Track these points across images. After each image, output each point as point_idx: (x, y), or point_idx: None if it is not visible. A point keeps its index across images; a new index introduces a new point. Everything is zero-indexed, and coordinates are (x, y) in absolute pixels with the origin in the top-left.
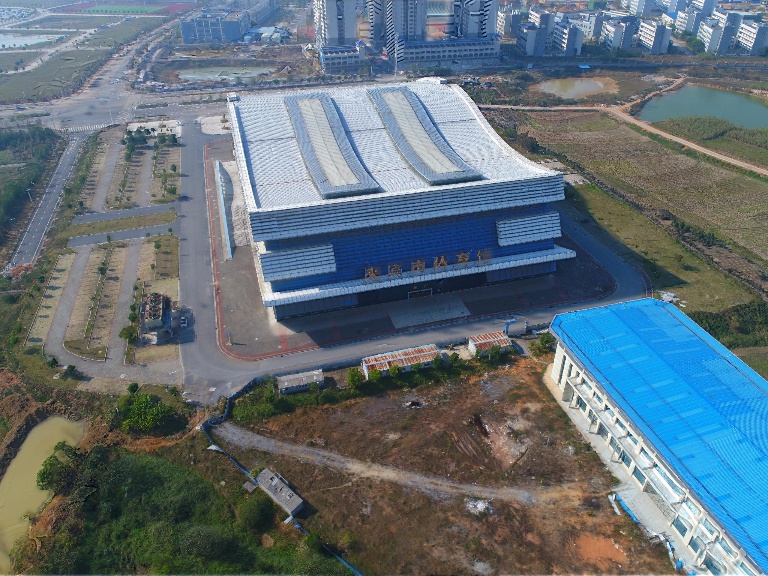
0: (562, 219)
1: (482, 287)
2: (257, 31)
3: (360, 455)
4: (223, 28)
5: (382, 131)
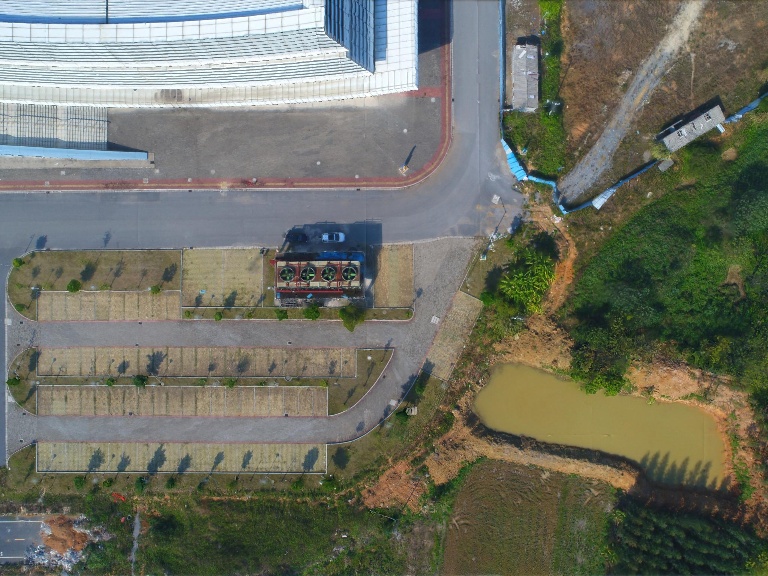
0: None
1: None
2: None
3: (657, 34)
4: None
5: None
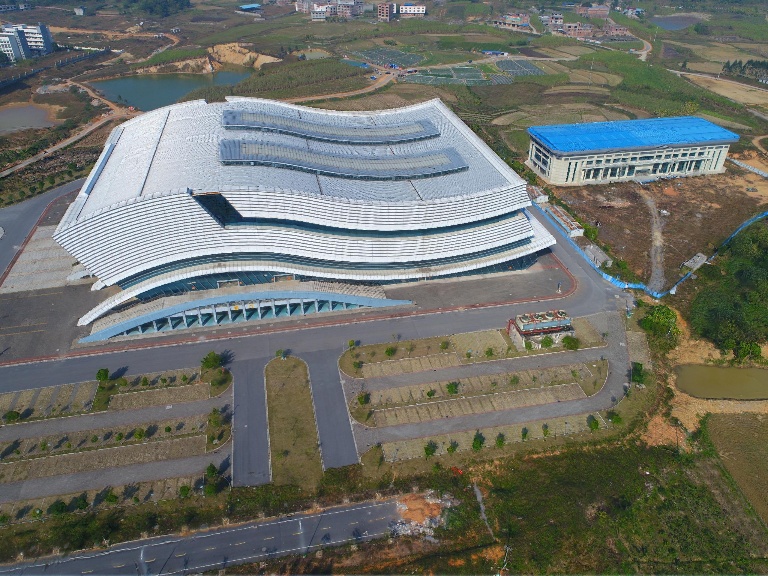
0: None
1: None
2: None
3: None
4: None
5: (312, 141)
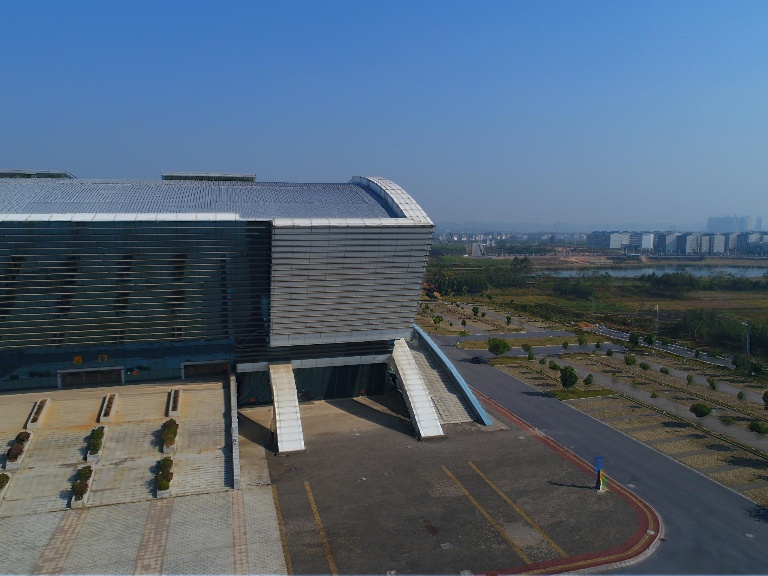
0: None
1: None
2: None
3: None
4: None
5: None
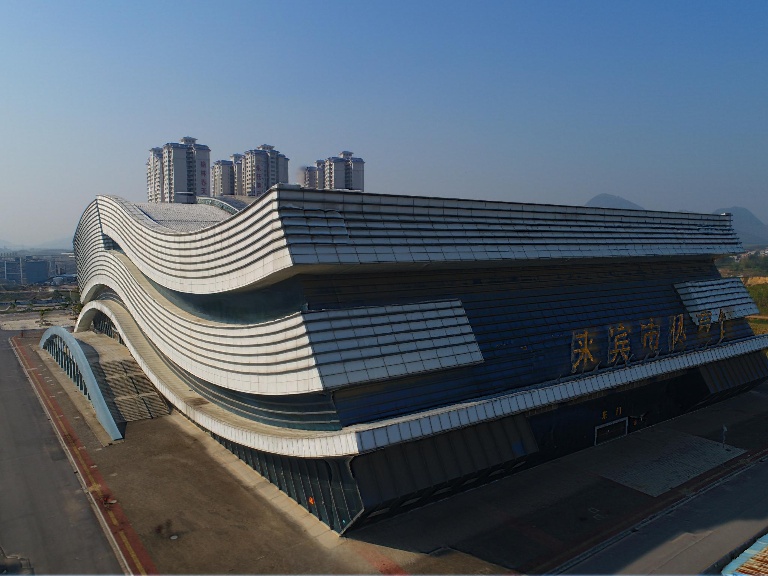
0: None
1: (687, 414)
2: (70, 275)
3: None
4: (24, 269)
5: None
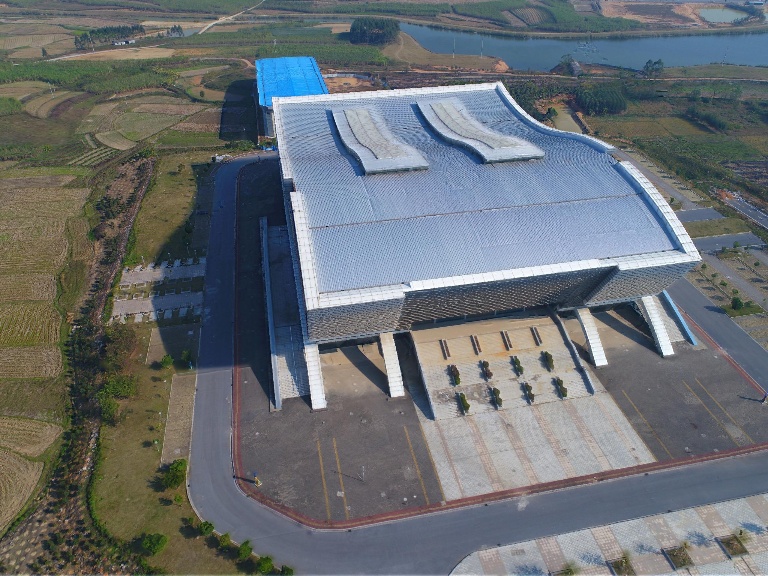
0: (222, 218)
1: None
2: None
3: None
4: None
5: None
